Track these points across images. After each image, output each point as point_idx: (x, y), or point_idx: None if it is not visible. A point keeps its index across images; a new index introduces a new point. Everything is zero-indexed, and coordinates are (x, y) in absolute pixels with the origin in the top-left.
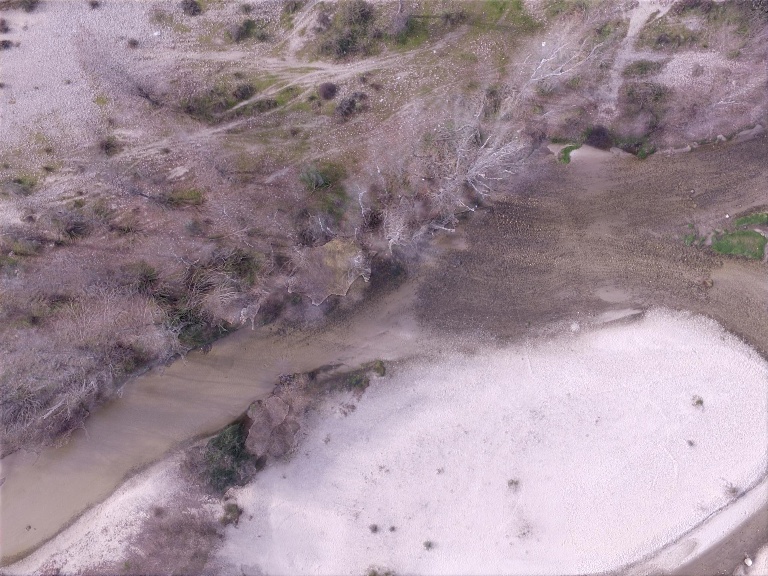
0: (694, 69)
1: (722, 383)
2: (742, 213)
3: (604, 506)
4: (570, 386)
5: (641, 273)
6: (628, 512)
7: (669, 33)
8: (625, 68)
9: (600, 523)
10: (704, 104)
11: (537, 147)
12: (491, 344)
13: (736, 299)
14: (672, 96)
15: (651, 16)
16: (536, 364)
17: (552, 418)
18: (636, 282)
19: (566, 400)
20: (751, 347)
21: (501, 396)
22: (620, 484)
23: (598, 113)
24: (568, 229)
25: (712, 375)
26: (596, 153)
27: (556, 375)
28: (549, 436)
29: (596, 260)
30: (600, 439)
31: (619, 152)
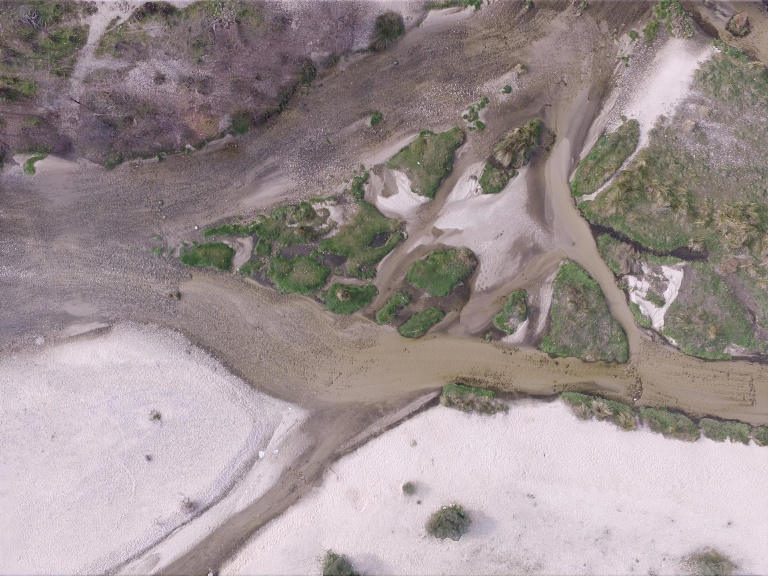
0: (154, 77)
1: (181, 398)
2: (212, 224)
3: (60, 522)
4: (27, 401)
5: (109, 286)
6: (84, 528)
7: (128, 40)
8: (85, 76)
9: (56, 539)
10: (166, 113)
11: (1, 158)
12: None
13: (204, 312)
14: (135, 105)
15: (111, 23)
16: None
17: (7, 434)
18: (104, 295)
19: (22, 415)
20: (217, 361)
21: None
22: (76, 500)
23: (62, 123)
24: (34, 241)
25: (171, 389)
26: (62, 164)
27: (15, 390)
28: (4, 452)
29: (63, 273)
30: (56, 455)
31: (86, 163)
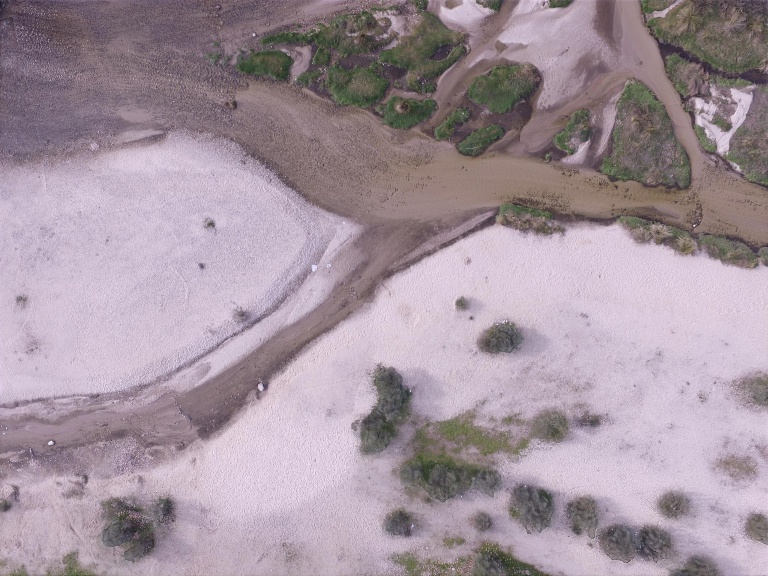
0: None
1: (236, 206)
2: (271, 32)
3: (113, 326)
4: (82, 205)
5: (165, 93)
6: (137, 333)
7: None
8: None
9: (109, 342)
10: None
11: None
12: (9, 161)
13: (260, 122)
14: None
15: None
16: (52, 182)
17: (62, 236)
18: (159, 102)
19: (77, 218)
20: (272, 172)
21: (12, 213)
22: (130, 304)
23: None
24: (90, 44)
25: (226, 198)
26: None
27: (70, 194)
28: (59, 254)
29: (118, 78)
30: (110, 259)
31: None
